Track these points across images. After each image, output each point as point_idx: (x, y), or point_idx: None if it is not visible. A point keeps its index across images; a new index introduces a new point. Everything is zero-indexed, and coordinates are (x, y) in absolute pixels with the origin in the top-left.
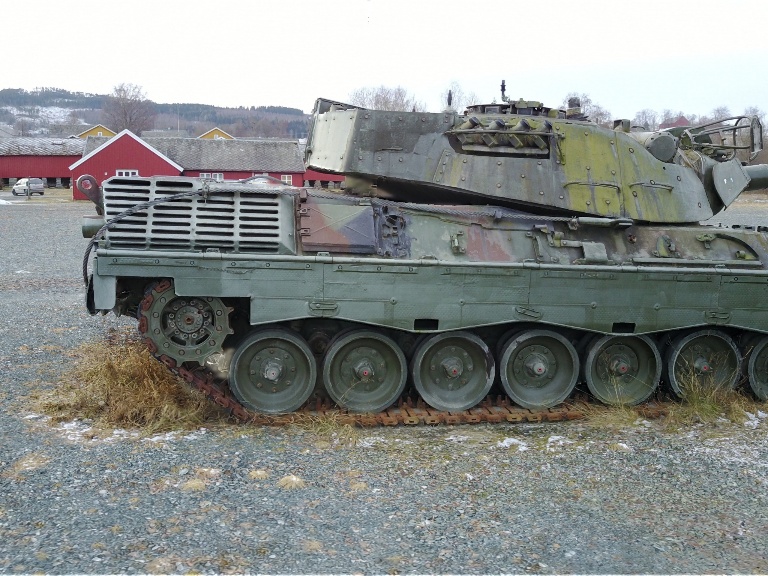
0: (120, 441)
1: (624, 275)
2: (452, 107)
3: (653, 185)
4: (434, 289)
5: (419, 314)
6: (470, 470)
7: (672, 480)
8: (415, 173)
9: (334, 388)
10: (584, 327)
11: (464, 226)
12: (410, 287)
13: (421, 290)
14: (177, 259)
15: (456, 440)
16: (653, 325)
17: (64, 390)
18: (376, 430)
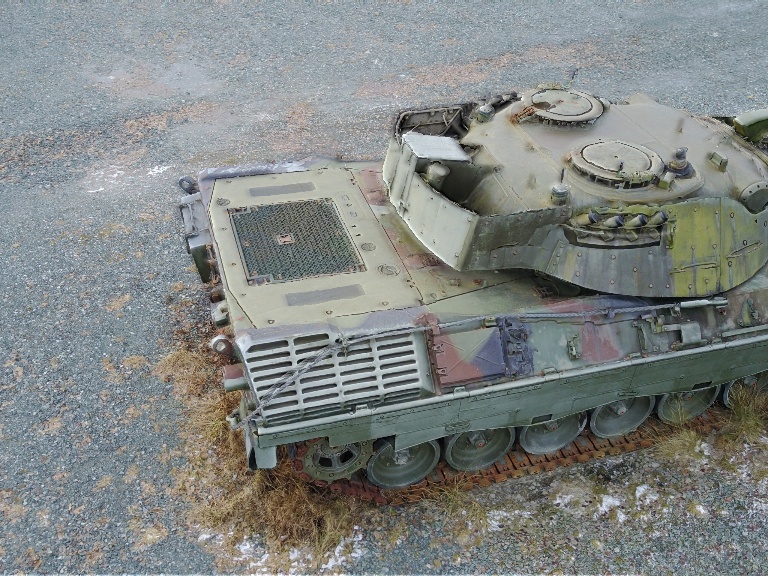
0: (303, 574)
1: (713, 353)
2: (565, 184)
3: (745, 245)
4: (553, 395)
5: (537, 414)
6: (594, 571)
7: (748, 568)
8: (528, 263)
9: (453, 459)
10: (670, 392)
11: (578, 326)
12: (533, 398)
13: (542, 398)
14: (331, 424)
15: (563, 504)
16: (726, 379)
17: (199, 465)
18: (491, 491)
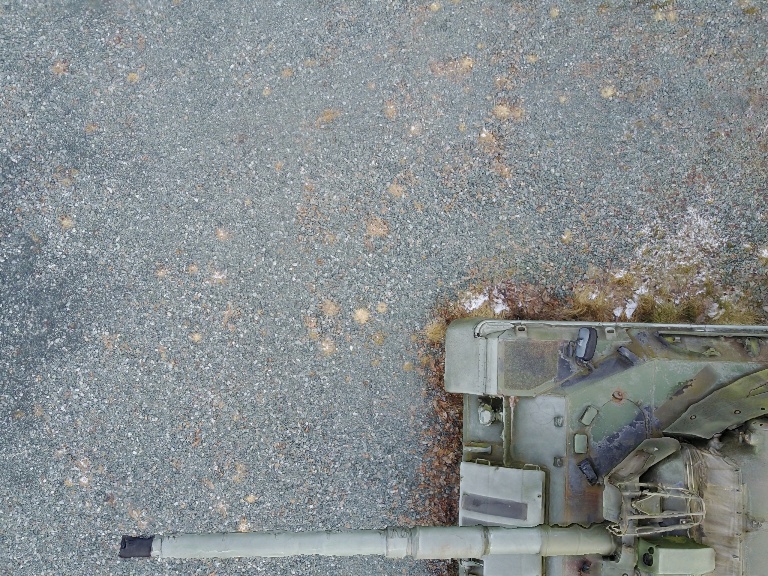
0: None
1: None
2: None
3: None
4: None
5: None
6: None
7: (763, 197)
8: None
9: None
10: None
11: None
12: None
13: None
14: None
15: None
16: None
17: None
18: None
